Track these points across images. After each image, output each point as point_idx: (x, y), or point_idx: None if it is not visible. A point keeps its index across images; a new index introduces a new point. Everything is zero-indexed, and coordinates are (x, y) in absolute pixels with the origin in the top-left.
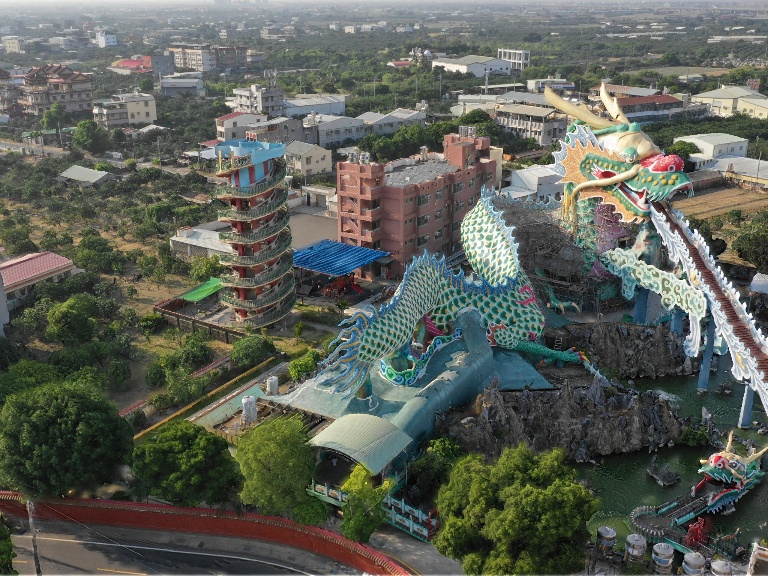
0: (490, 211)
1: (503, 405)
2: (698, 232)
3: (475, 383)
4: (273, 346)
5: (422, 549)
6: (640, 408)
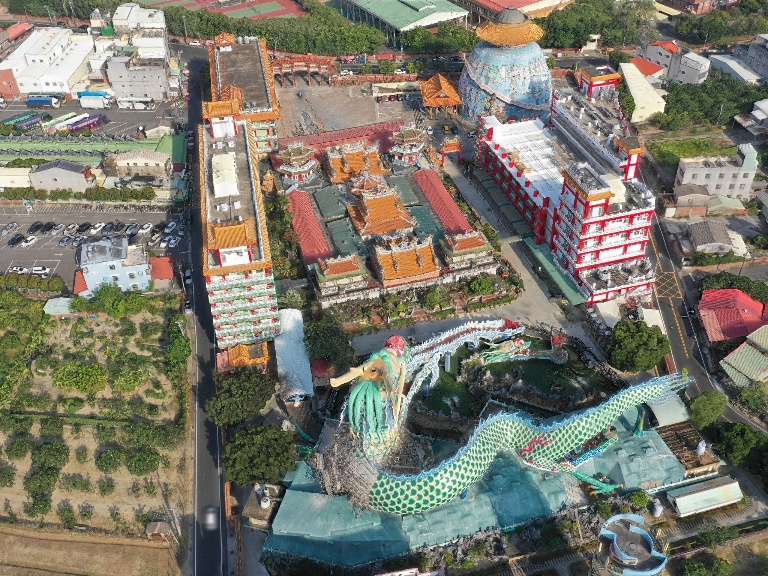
0: None
1: None
2: (268, 427)
3: None
4: None
5: None
6: (495, 385)
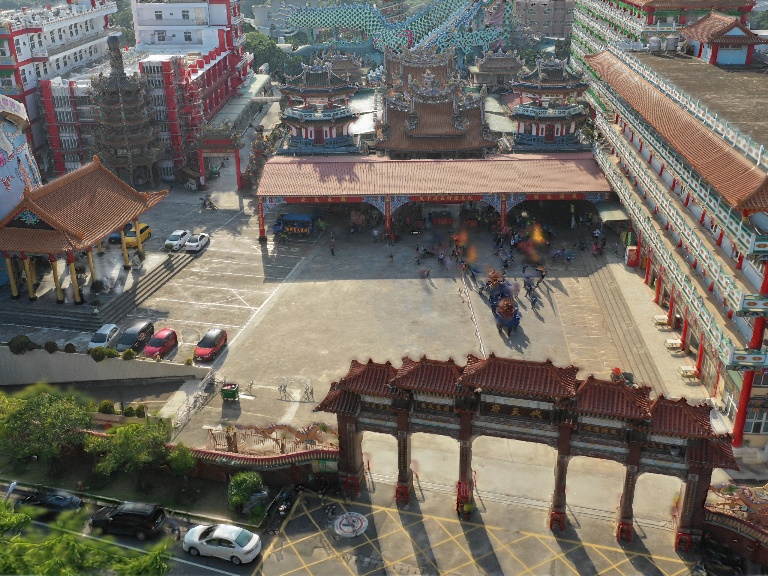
0: (438, 1)
1: None
2: None
3: None
4: None
5: None
6: None
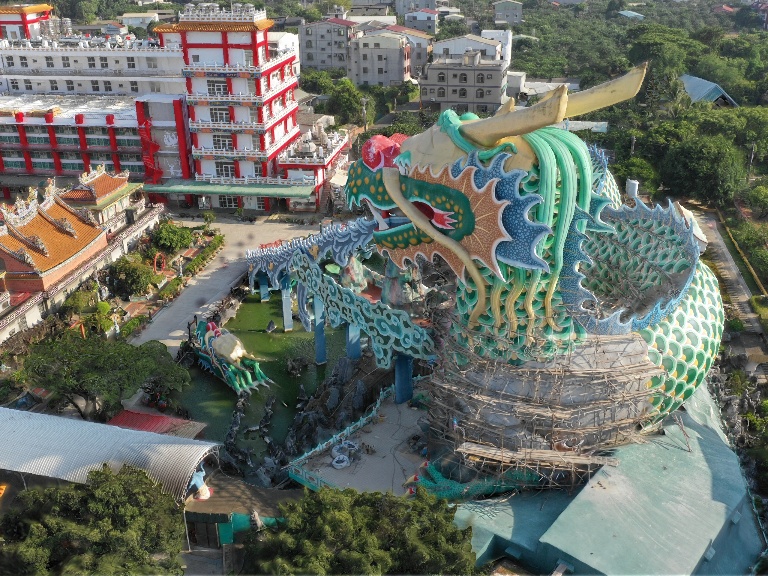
0: None
1: None
2: None
3: None
4: None
5: None
6: None
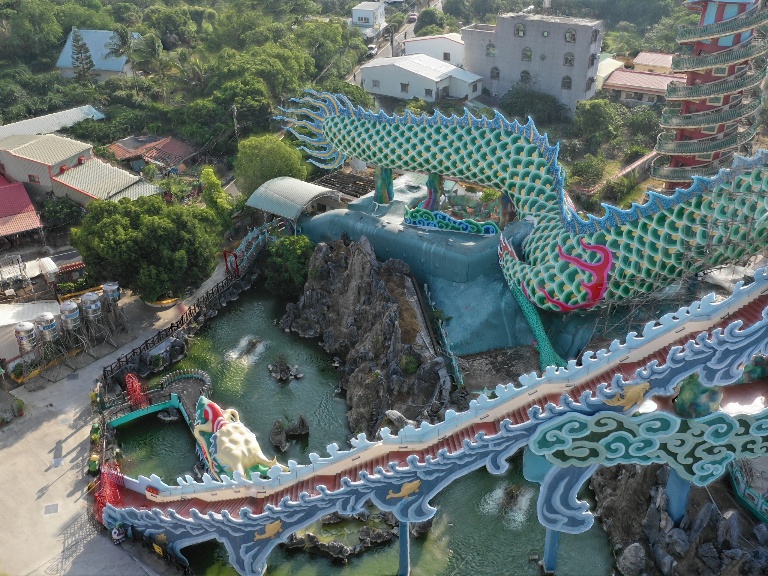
0: None
1: (359, 271)
2: None
3: (423, 265)
4: (594, 206)
5: (220, 270)
6: None
